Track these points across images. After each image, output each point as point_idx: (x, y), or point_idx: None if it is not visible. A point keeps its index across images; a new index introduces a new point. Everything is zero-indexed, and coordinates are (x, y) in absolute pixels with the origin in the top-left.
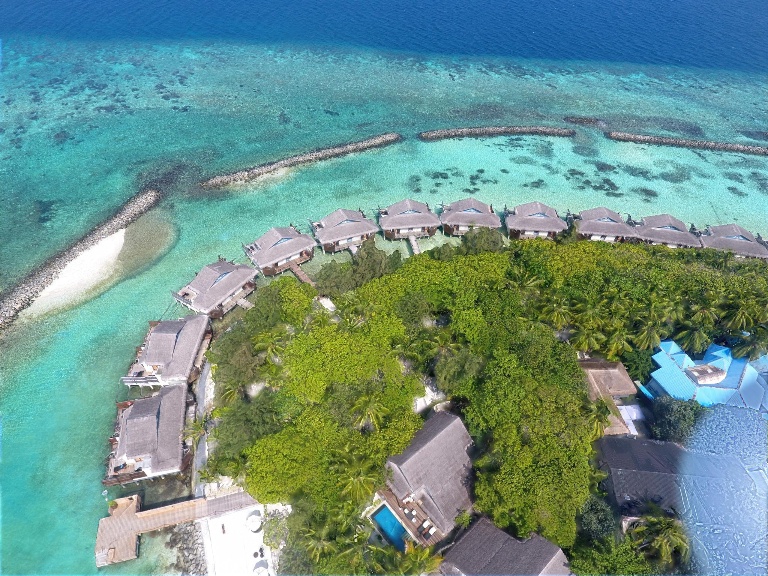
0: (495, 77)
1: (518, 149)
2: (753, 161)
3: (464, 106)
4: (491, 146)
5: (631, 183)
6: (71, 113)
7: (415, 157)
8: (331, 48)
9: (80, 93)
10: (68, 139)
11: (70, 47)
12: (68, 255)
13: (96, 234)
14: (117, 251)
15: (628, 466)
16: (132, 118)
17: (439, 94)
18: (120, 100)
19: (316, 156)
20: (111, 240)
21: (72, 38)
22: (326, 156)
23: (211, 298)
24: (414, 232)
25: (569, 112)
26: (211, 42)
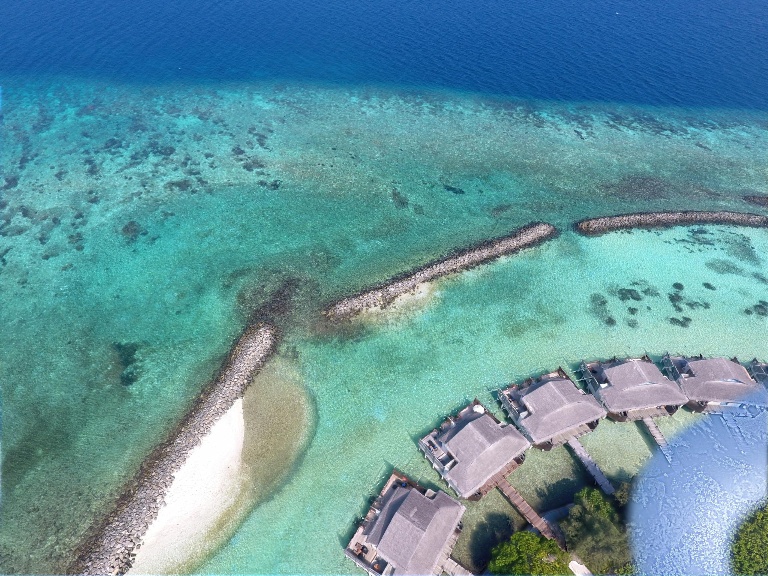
0: (630, 134)
1: (709, 248)
2: None
3: (612, 178)
4: (673, 243)
5: None
6: (138, 192)
7: (584, 262)
8: (422, 93)
9: (144, 161)
10: (140, 234)
11: (122, 93)
12: (173, 456)
13: (206, 413)
14: (239, 445)
15: None
16: (213, 200)
17: (574, 160)
18: (194, 172)
19: (461, 263)
20: (227, 423)
21: (124, 82)
22: (472, 262)
23: None
24: (647, 410)
25: (744, 187)
26: (283, 86)
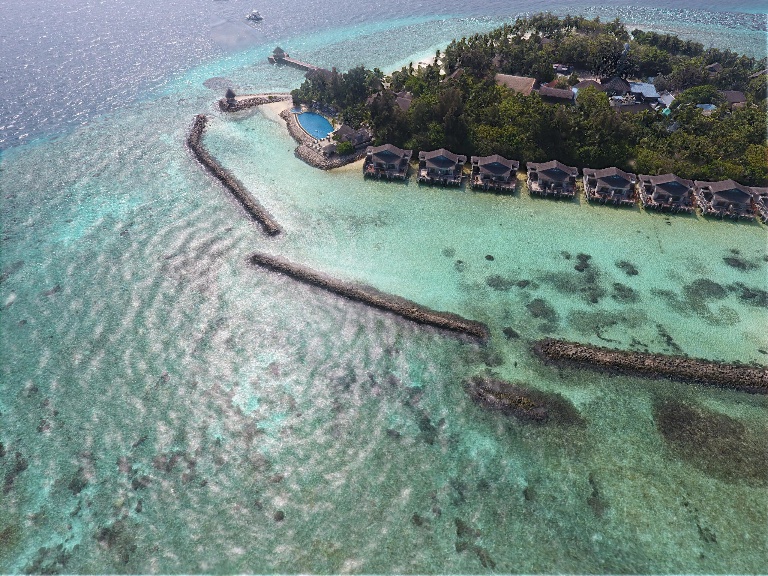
0: None
1: None
2: (587, 327)
3: None
4: None
5: (761, 276)
6: None
7: None
8: None
9: None
10: None
11: None
12: None
13: None
14: None
15: (736, 93)
16: None
17: None
18: None
19: None
20: None
21: None
22: None
23: None
24: None
25: None
26: None
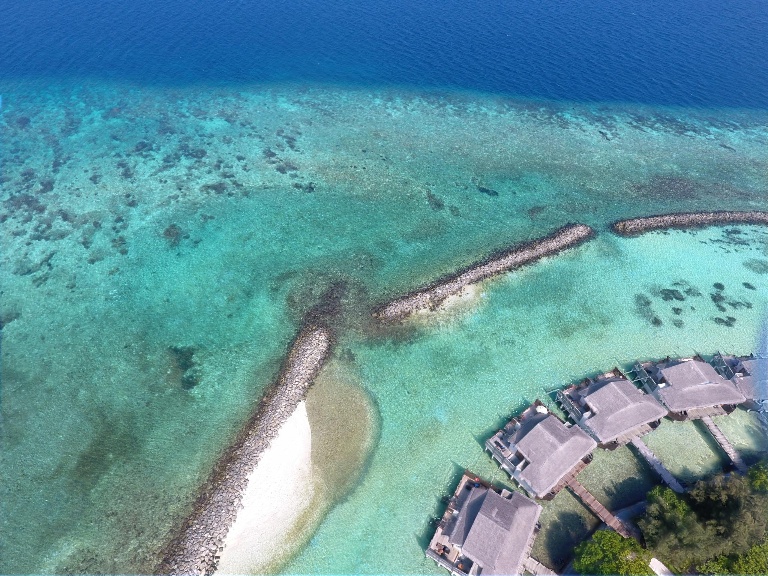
0: (654, 135)
1: (745, 248)
2: None
3: (642, 179)
4: (709, 243)
5: None
6: (175, 196)
7: (624, 263)
8: (445, 94)
9: (177, 164)
10: (182, 238)
11: (146, 96)
12: (244, 459)
13: (272, 416)
14: (307, 447)
15: None
16: (251, 203)
17: (603, 161)
18: (228, 174)
19: (504, 265)
20: (294, 426)
21: (147, 84)
22: (515, 264)
23: (503, 575)
24: (705, 409)
25: None
26: (305, 87)
